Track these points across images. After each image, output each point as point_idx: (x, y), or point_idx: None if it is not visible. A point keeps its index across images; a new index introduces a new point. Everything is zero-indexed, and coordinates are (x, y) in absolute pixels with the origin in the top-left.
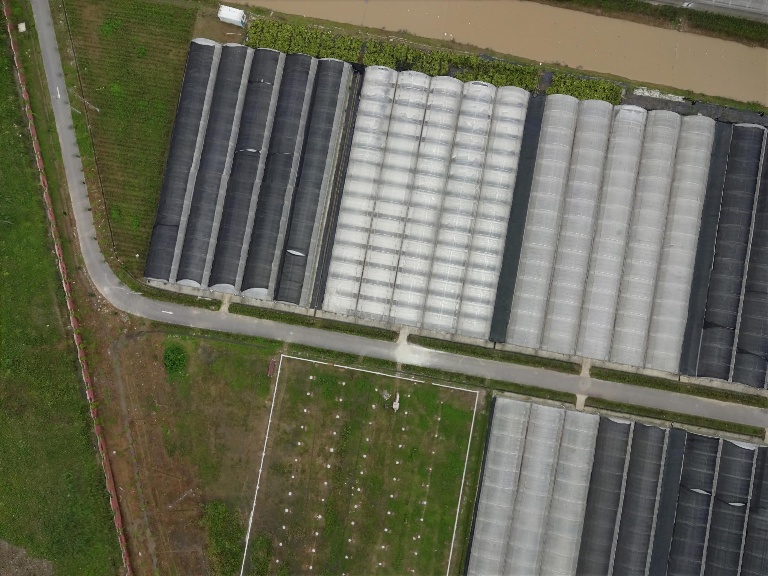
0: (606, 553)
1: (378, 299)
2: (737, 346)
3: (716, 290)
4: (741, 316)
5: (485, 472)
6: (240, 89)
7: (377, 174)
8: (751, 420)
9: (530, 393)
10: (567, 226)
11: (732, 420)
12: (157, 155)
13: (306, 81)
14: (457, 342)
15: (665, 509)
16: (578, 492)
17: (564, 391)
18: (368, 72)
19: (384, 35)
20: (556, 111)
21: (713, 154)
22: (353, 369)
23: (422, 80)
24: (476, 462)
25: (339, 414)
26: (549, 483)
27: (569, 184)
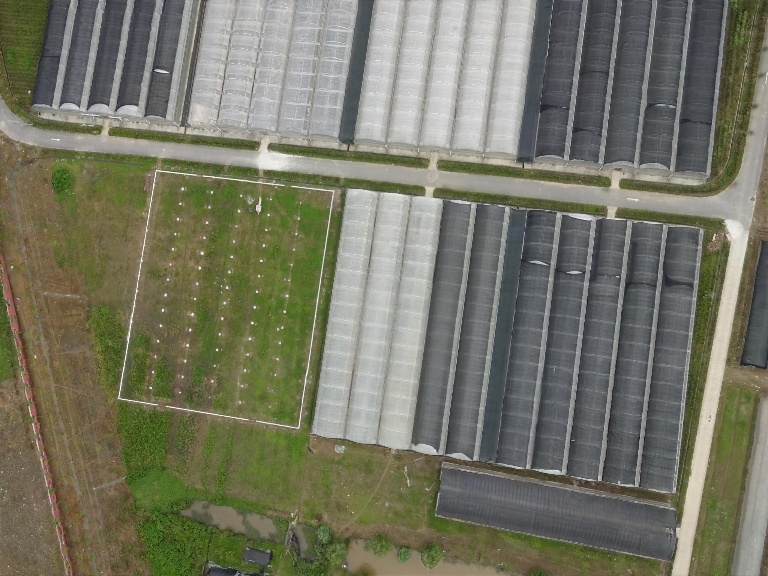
0: (450, 326)
1: (235, 107)
2: (573, 126)
3: (550, 74)
4: (576, 98)
5: (337, 259)
6: None
7: None
8: (593, 199)
9: (382, 189)
10: (407, 26)
11: (574, 200)
12: (45, 2)
13: None
14: (313, 147)
15: (510, 286)
16: (422, 270)
17: (413, 184)
18: None
19: None
20: None
21: None
22: (220, 178)
23: None
24: (333, 256)
25: (208, 220)
26: (395, 264)
27: None
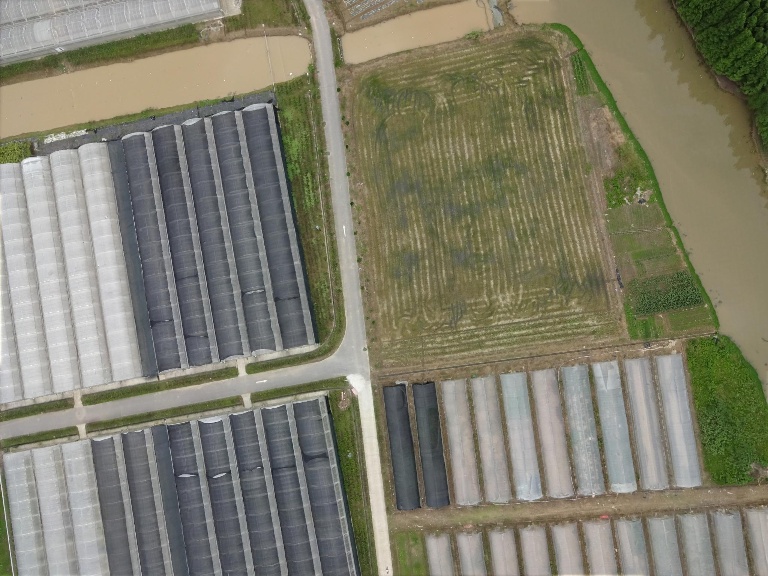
0: (126, 560)
1: None
2: (183, 333)
3: (148, 291)
4: (179, 305)
5: None
6: None
7: None
8: (227, 392)
9: (39, 439)
10: (9, 284)
11: (211, 399)
12: None
13: None
14: None
15: (174, 501)
16: (86, 515)
17: (65, 427)
18: None
19: None
20: None
21: (113, 172)
22: None
23: None
24: None
25: None
26: (62, 515)
27: None
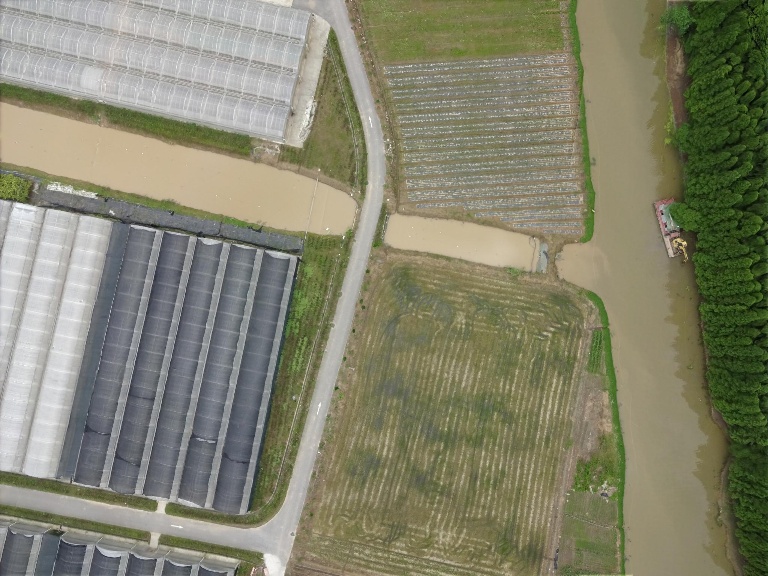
0: None
1: None
2: (116, 450)
3: (96, 393)
4: (123, 420)
5: None
6: None
7: None
8: (137, 524)
9: None
10: None
11: (118, 524)
12: None
13: None
14: None
15: None
16: None
17: None
18: None
19: None
20: None
21: (108, 254)
22: None
23: None
24: None
25: None
26: None
27: None
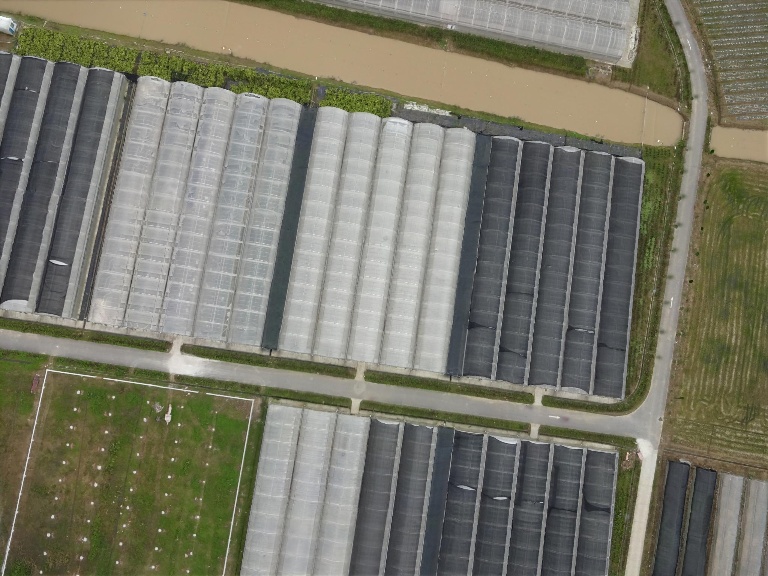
0: (376, 556)
1: (145, 308)
2: (499, 345)
3: (478, 292)
4: (503, 316)
5: (256, 481)
6: (3, 97)
7: (147, 183)
8: (517, 416)
9: (305, 399)
10: (336, 233)
11: (500, 417)
12: None
13: (74, 90)
14: (232, 350)
15: (436, 508)
16: (348, 496)
17: (339, 395)
18: (139, 82)
19: (161, 47)
20: (325, 122)
21: (475, 164)
22: (123, 382)
23: (194, 91)
24: (251, 472)
25: (108, 429)
26: (320, 488)
27: (340, 192)
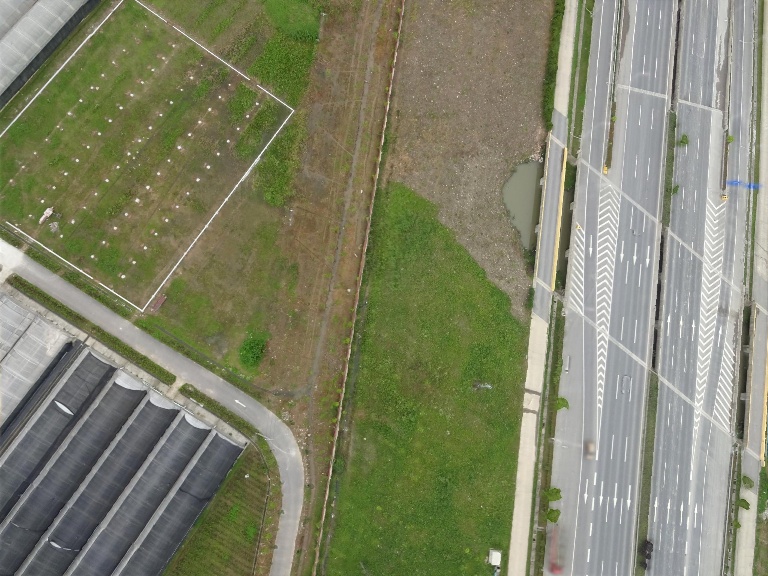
0: None
1: None
2: None
3: None
4: None
5: None
6: None
7: None
8: None
9: None
10: None
11: None
12: None
13: None
14: None
15: None
16: None
17: None
18: None
19: None
20: None
21: None
22: (75, 266)
23: None
24: None
25: (113, 230)
26: None
27: None
